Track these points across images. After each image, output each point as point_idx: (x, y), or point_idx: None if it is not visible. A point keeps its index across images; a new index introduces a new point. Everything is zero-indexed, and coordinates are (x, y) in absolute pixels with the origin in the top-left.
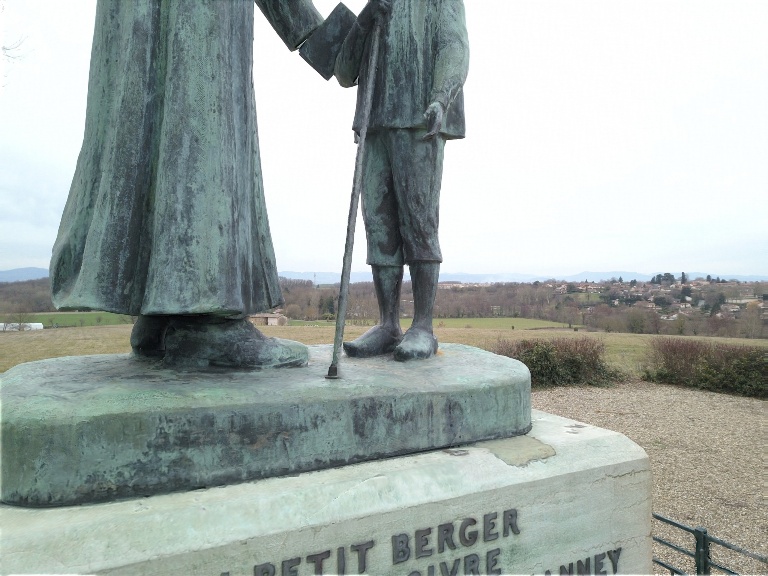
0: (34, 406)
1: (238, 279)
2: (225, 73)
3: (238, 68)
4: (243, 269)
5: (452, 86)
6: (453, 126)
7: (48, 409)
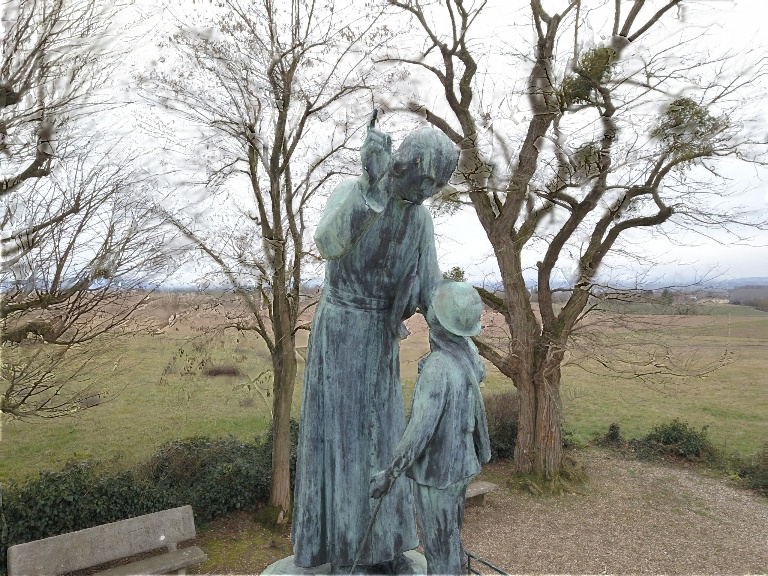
0: (268, 571)
1: (304, 550)
2: (307, 445)
3: (338, 429)
4: (341, 539)
5: (395, 458)
6: (434, 479)
7: (263, 575)
